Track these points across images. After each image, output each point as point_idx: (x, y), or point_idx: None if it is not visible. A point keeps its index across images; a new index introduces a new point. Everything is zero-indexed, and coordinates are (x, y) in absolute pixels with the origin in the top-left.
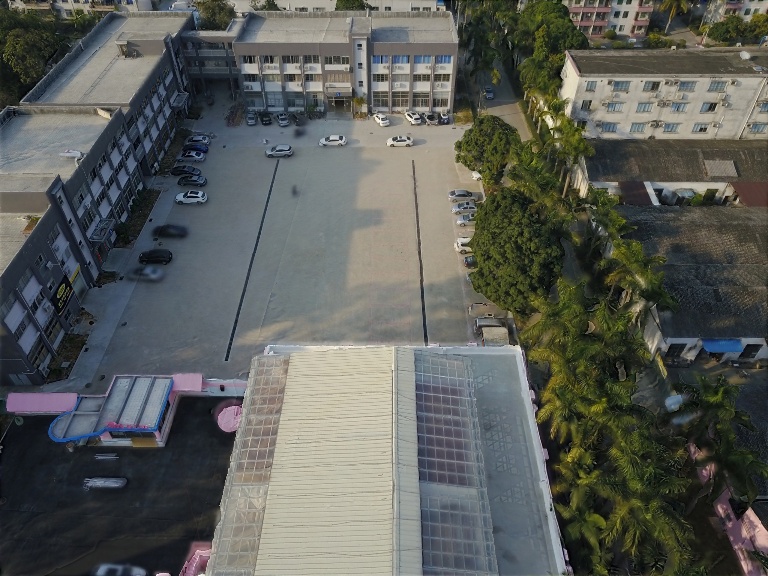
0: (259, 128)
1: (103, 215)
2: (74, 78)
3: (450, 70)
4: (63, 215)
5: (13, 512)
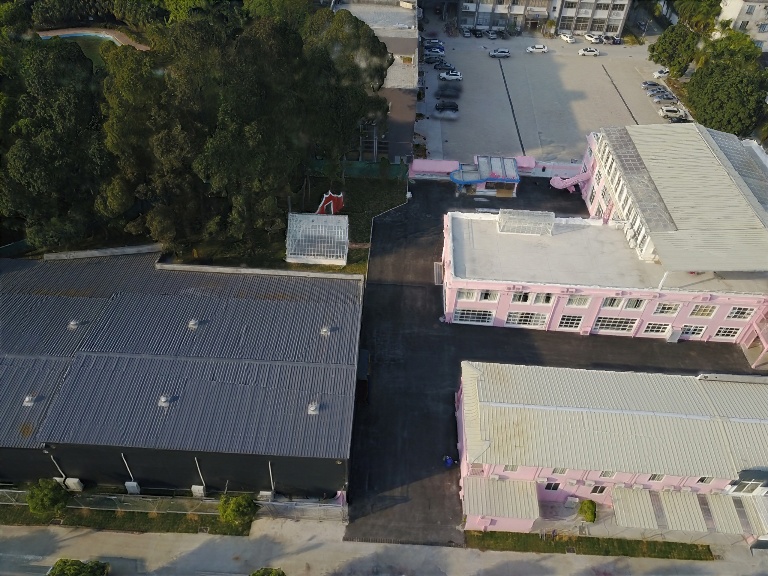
0: (474, 39)
1: None
2: None
3: (626, 1)
4: None
5: (439, 220)
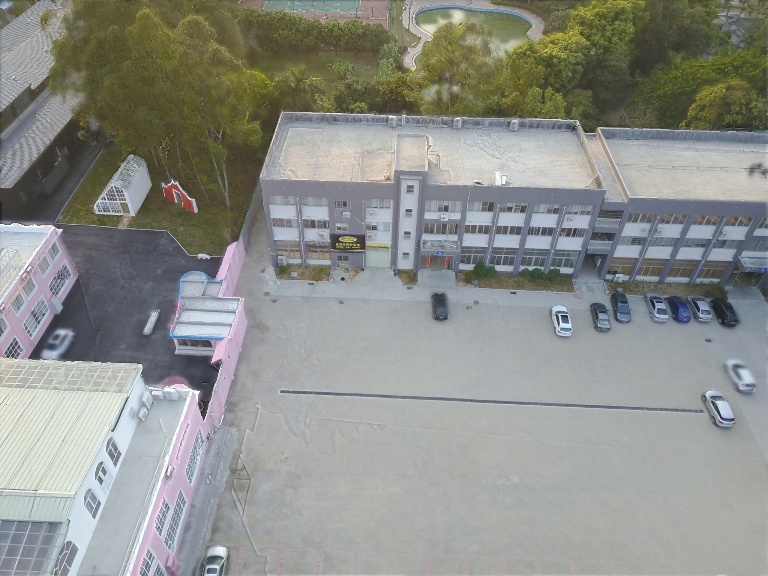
0: None
1: (468, 242)
2: (689, 151)
3: None
4: (399, 199)
5: (147, 278)
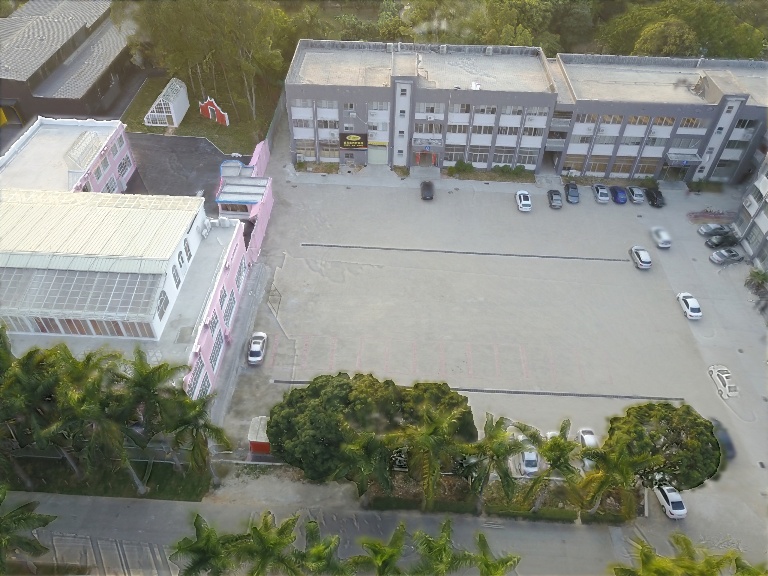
0: (697, 240)
1: (450, 141)
2: (630, 72)
3: None
4: (395, 101)
5: (192, 169)
